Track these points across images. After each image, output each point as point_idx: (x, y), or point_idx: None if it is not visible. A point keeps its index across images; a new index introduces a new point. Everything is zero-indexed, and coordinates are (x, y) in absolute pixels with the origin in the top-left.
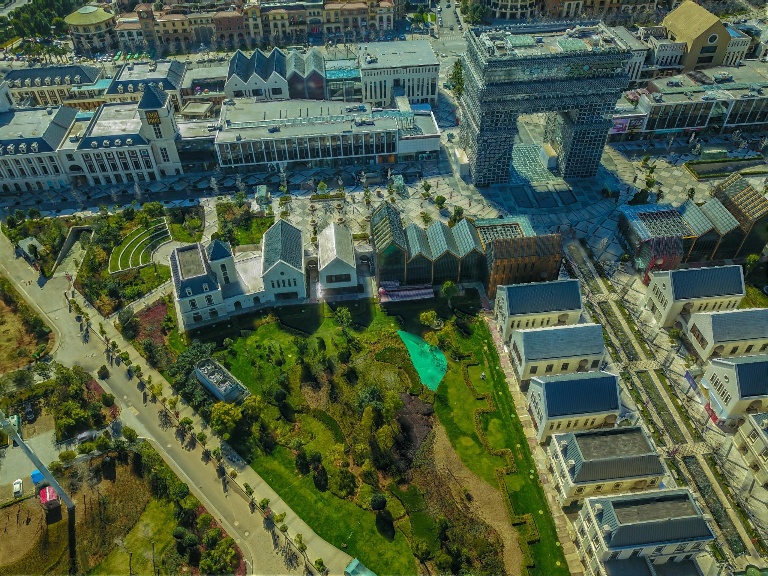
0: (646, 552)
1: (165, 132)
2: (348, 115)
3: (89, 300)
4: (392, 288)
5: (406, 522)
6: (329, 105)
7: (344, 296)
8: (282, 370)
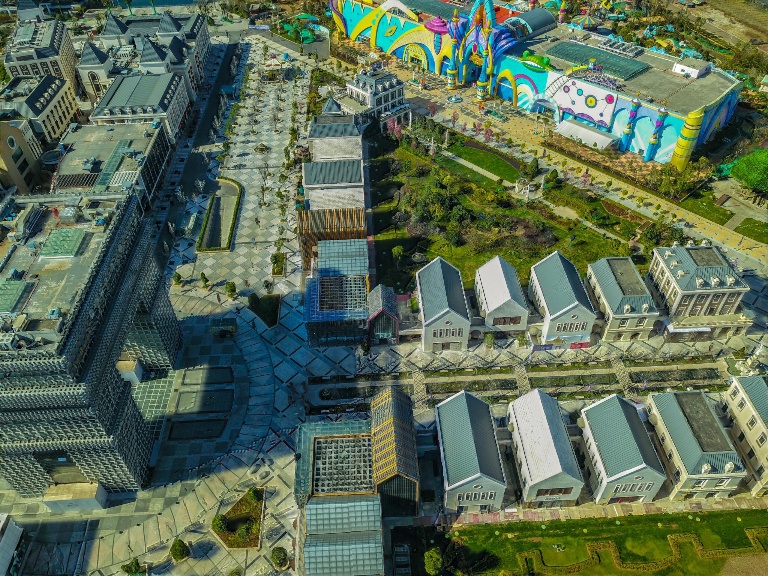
0: None
1: None
2: None
3: None
4: None
5: None
6: None
7: None
8: None
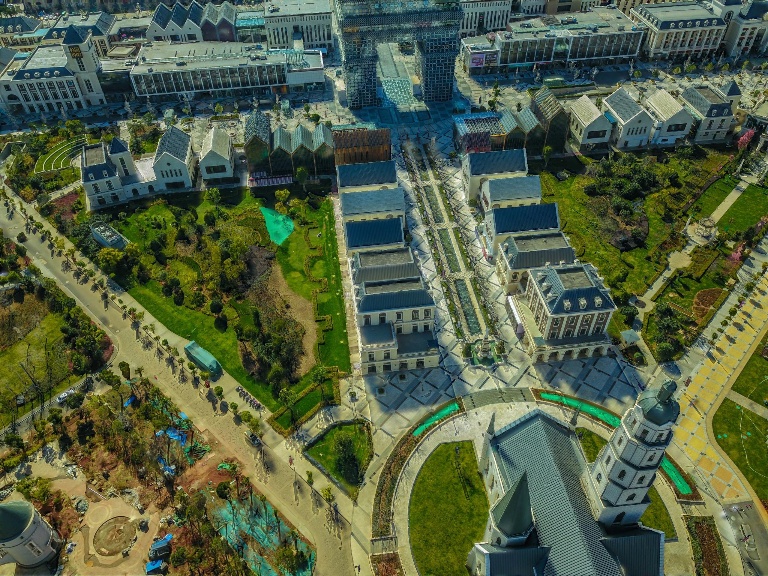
0: (390, 319)
1: (87, 65)
2: (246, 52)
3: (16, 192)
4: (260, 177)
5: None
6: (232, 45)
7: (223, 186)
8: None
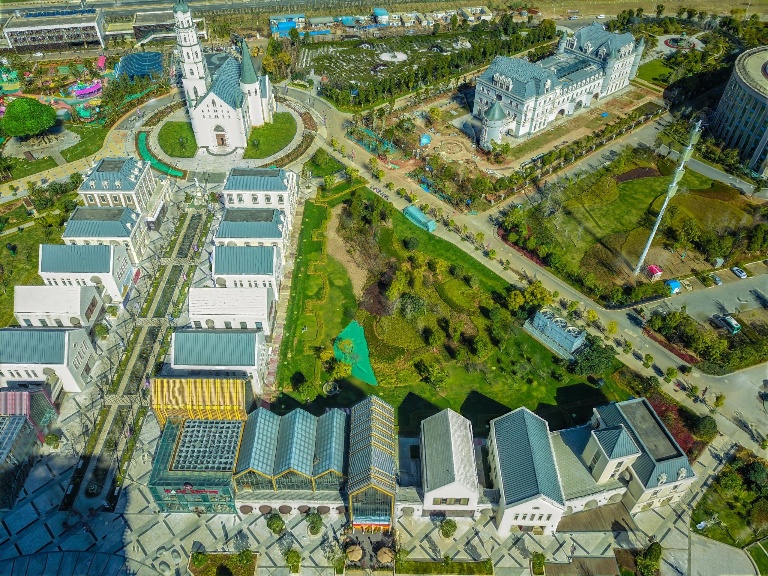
0: None
1: None
2: None
3: None
4: None
5: (395, 242)
6: None
7: None
8: (499, 349)
